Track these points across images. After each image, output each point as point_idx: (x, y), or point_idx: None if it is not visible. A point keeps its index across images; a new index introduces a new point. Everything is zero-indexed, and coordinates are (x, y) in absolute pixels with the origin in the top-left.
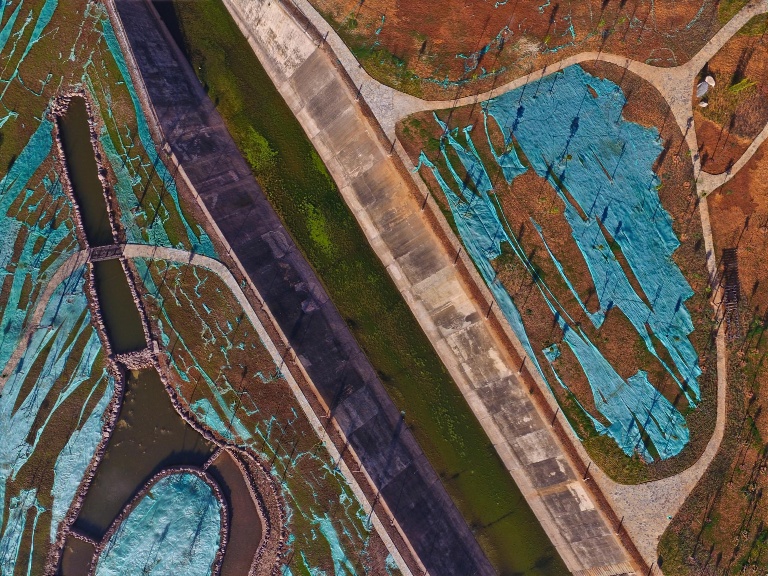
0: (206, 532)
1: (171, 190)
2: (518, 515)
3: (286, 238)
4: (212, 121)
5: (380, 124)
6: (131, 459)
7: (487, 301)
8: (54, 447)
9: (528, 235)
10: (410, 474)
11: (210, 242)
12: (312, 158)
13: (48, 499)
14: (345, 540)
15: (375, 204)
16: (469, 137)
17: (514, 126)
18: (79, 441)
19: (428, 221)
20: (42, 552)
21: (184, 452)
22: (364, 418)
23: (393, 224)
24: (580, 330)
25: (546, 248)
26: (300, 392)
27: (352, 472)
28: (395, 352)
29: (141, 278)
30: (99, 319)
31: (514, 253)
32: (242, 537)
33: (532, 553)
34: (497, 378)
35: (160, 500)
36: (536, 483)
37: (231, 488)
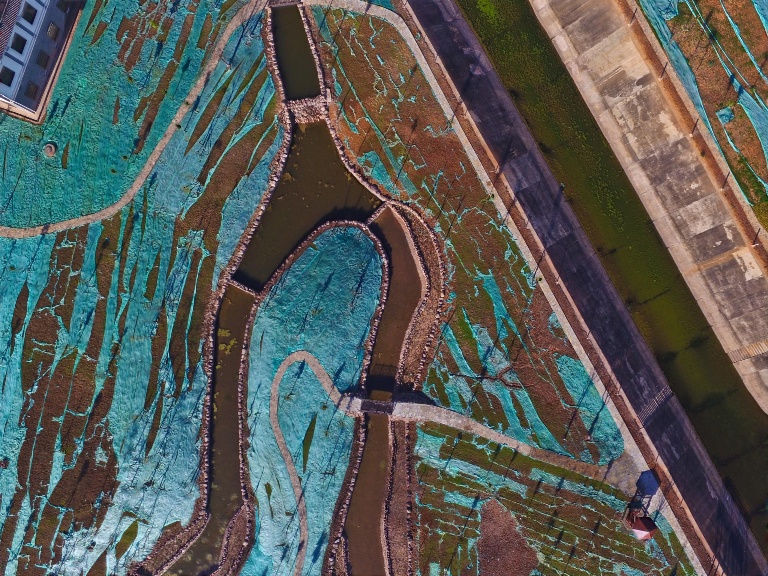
0: (368, 285)
1: None
2: (675, 293)
3: (453, 6)
4: None
5: None
6: (293, 214)
7: (661, 62)
8: (223, 189)
9: None
10: (571, 242)
11: None
12: None
13: (214, 243)
14: (508, 297)
15: None
16: None
17: None
18: (247, 187)
19: None
20: (203, 298)
21: (347, 208)
22: (529, 181)
23: None
24: (755, 93)
25: (723, 10)
26: (470, 146)
27: (519, 228)
28: (557, 124)
29: (317, 26)
30: (274, 64)
31: (691, 14)
32: (401, 296)
33: (687, 332)
34: (665, 144)
35: (324, 250)
36: (697, 257)
37: (392, 246)
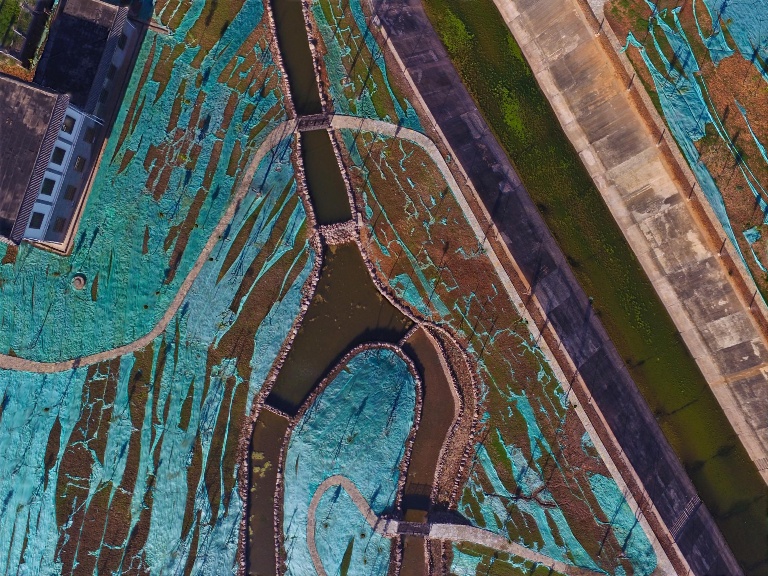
0: (402, 407)
1: (379, 63)
2: (702, 403)
3: (481, 121)
4: (412, 1)
5: (589, 3)
6: (325, 335)
7: (689, 182)
8: (256, 316)
9: (732, 118)
10: (601, 357)
11: (416, 116)
12: (508, 42)
13: (247, 369)
14: (542, 417)
15: (574, 87)
16: (677, 19)
17: (722, 9)
18: (279, 312)
19: (633, 101)
20: (237, 424)
21: (379, 329)
22: (559, 299)
23: (593, 107)
24: None
25: (750, 131)
26: (502, 268)
27: (551, 349)
28: (585, 238)
29: (347, 150)
30: (305, 189)
31: (718, 135)
32: (434, 415)
33: (715, 441)
34: (693, 261)
35: (357, 374)
36: (724, 369)
37: (425, 366)
